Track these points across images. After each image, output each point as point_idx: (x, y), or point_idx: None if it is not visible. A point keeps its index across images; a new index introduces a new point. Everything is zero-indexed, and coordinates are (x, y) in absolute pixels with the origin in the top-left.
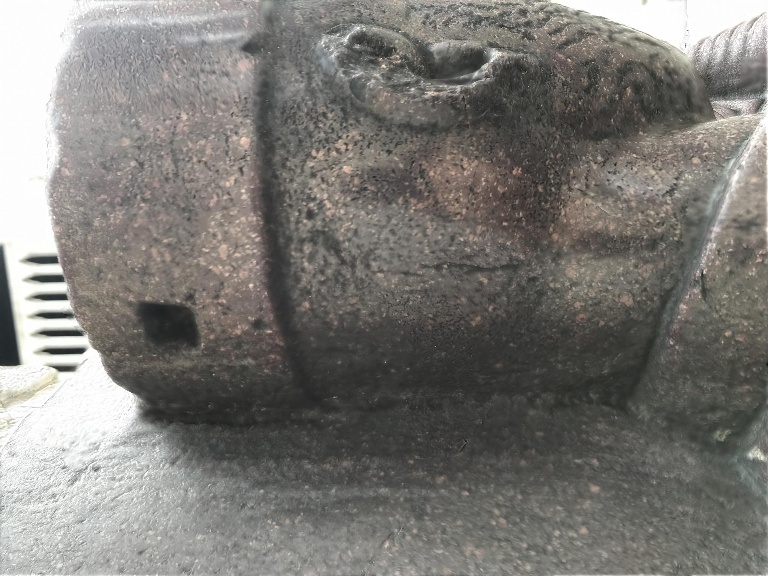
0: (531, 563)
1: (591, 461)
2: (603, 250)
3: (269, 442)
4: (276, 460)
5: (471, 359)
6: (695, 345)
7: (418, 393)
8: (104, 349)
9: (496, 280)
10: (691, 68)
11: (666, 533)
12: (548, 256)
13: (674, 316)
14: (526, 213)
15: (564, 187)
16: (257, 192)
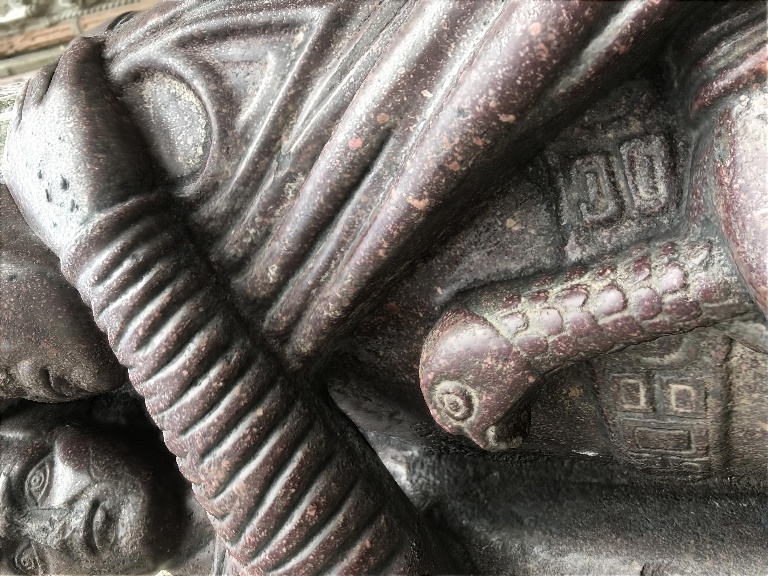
0: None
1: None
2: None
3: None
4: None
5: None
6: None
7: None
8: None
9: None
10: (151, 572)
11: None
12: None
13: None
14: None
15: None
16: None
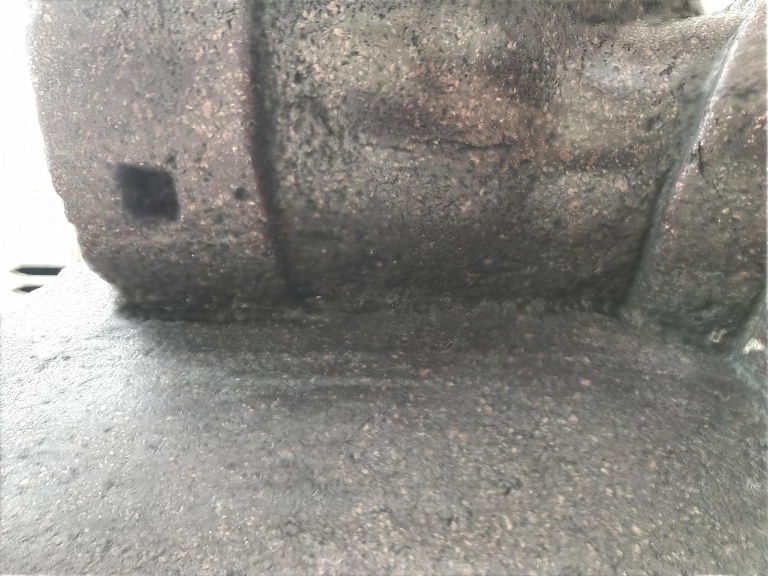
0: (517, 445)
1: (582, 358)
2: (598, 130)
3: (248, 339)
4: (254, 354)
5: (460, 252)
6: (691, 227)
7: (405, 295)
8: (80, 221)
9: (488, 161)
10: None
11: (659, 420)
12: (542, 138)
13: (670, 197)
14: (520, 89)
15: (560, 65)
16: (245, 47)
